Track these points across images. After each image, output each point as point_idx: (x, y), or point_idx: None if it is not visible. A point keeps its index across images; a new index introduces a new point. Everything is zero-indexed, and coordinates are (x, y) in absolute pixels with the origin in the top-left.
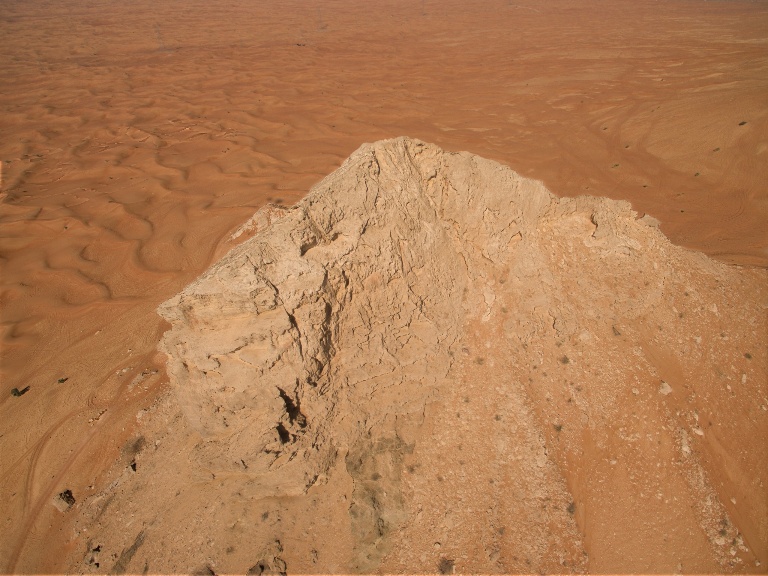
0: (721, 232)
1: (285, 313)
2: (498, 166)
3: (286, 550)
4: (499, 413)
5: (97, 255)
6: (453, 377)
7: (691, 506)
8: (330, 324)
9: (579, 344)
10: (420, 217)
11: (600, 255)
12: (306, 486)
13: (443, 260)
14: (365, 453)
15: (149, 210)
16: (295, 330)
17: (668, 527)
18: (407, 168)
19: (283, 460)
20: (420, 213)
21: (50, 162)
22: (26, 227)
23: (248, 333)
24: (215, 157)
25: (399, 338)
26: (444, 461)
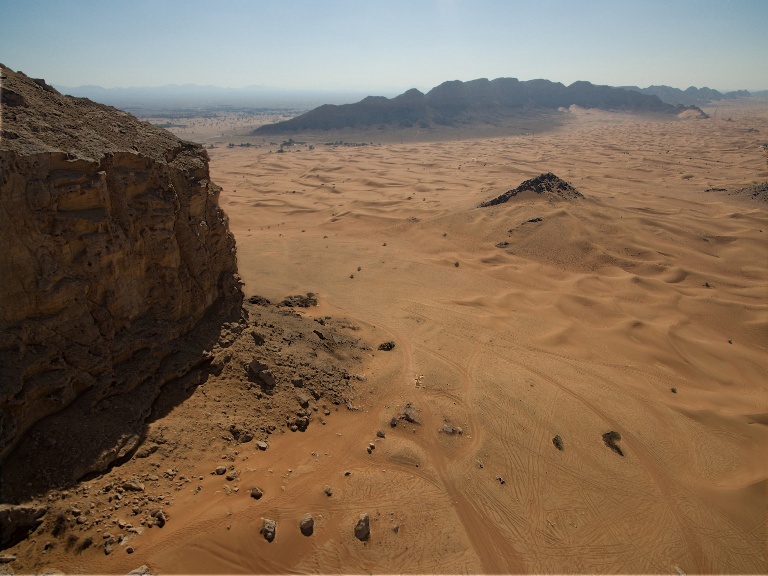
0: None
1: None
2: None
3: None
4: None
5: None
6: None
7: None
8: None
9: None
10: None
11: None
12: None
13: None
14: None
15: None
16: None
17: None
18: None
19: None
20: None
21: None
22: None
23: None
24: None
25: None
26: None
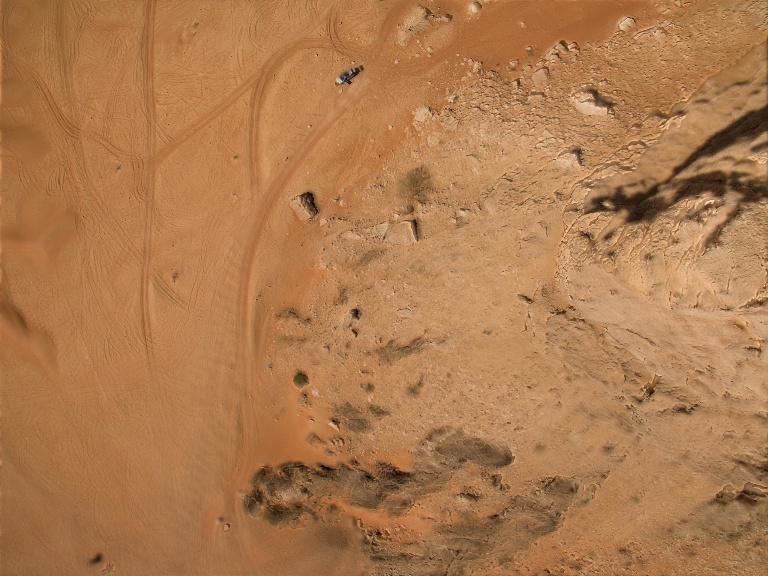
0: None
1: None
2: None
3: (610, 478)
4: None
5: None
6: None
7: None
8: None
9: None
10: None
11: None
12: None
13: None
14: None
15: None
16: None
17: None
18: None
19: None
20: None
21: None
22: None
23: None
24: None
25: None
26: None
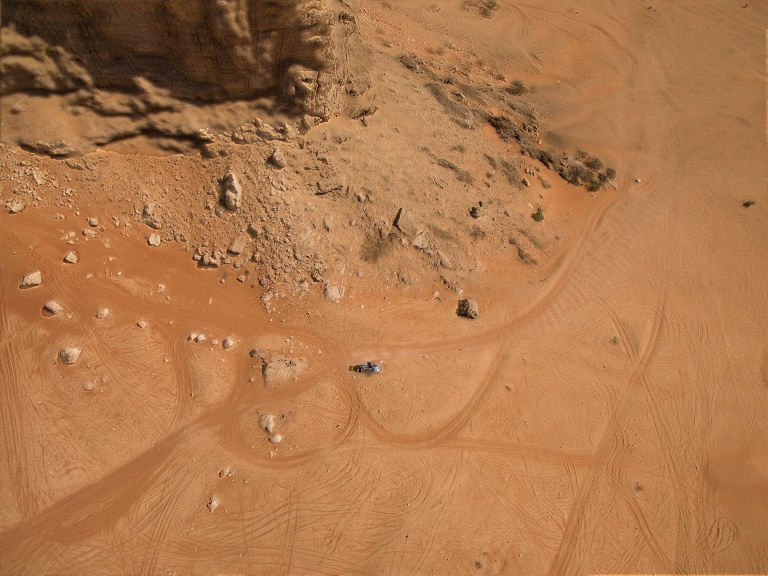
0: None
1: None
2: None
3: None
4: None
5: None
6: None
7: None
8: None
9: None
10: None
11: None
12: None
13: None
14: None
15: None
16: None
17: None
18: None
19: None
20: None
21: None
22: None
23: None
24: None
25: None
26: None
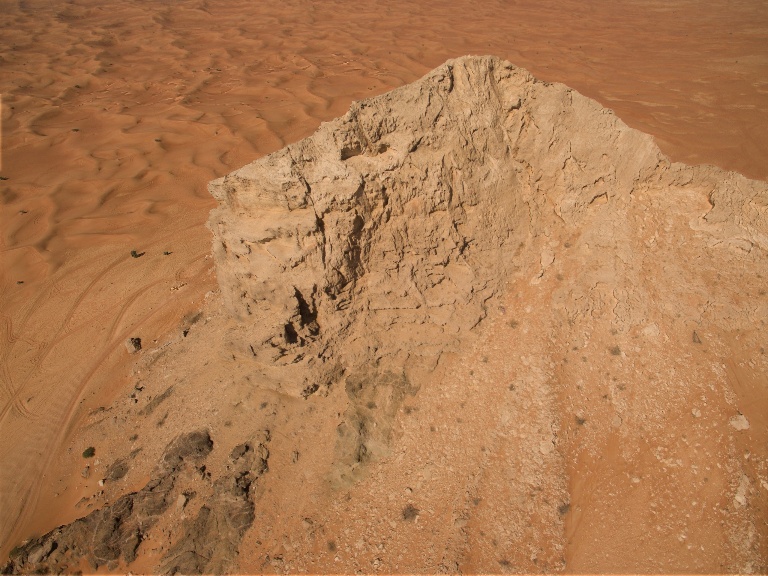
0: None
1: (314, 215)
2: (598, 108)
3: (273, 442)
4: (515, 383)
5: (232, 161)
6: (479, 332)
7: (721, 564)
8: (360, 240)
9: (640, 338)
10: (487, 150)
11: (707, 243)
12: (304, 390)
13: (503, 205)
14: (367, 379)
15: (287, 130)
16: (320, 234)
17: (679, 575)
18: (485, 91)
19: (289, 359)
20: (488, 145)
21: (225, 77)
22: (188, 127)
23: (276, 226)
24: (360, 92)
25: (431, 275)
26: (442, 413)
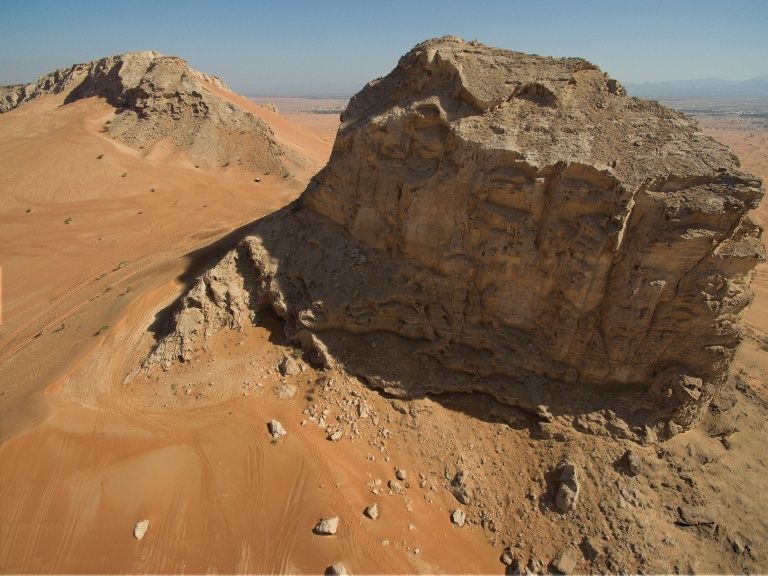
0: (250, 200)
1: None
2: None
3: None
4: None
5: None
6: None
7: None
8: None
9: None
10: None
11: None
12: None
13: None
14: None
15: None
16: None
17: None
18: None
19: None
20: None
21: None
22: None
23: None
24: None
25: None
26: None
